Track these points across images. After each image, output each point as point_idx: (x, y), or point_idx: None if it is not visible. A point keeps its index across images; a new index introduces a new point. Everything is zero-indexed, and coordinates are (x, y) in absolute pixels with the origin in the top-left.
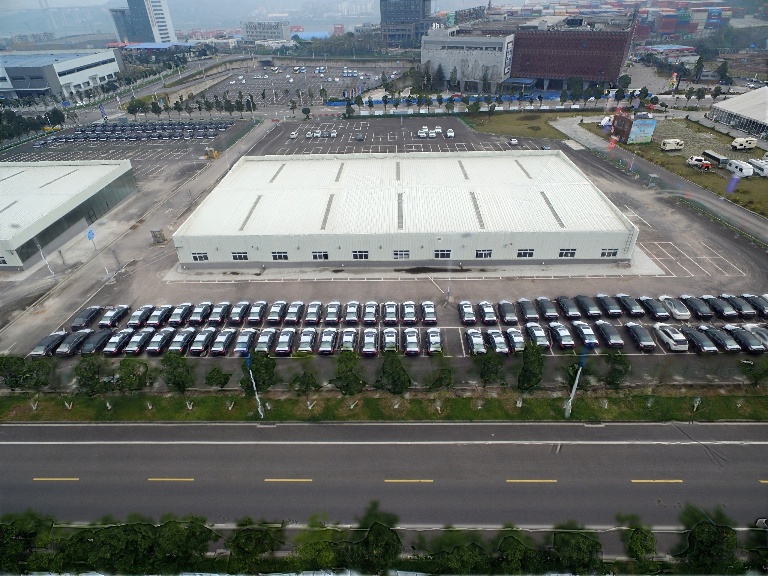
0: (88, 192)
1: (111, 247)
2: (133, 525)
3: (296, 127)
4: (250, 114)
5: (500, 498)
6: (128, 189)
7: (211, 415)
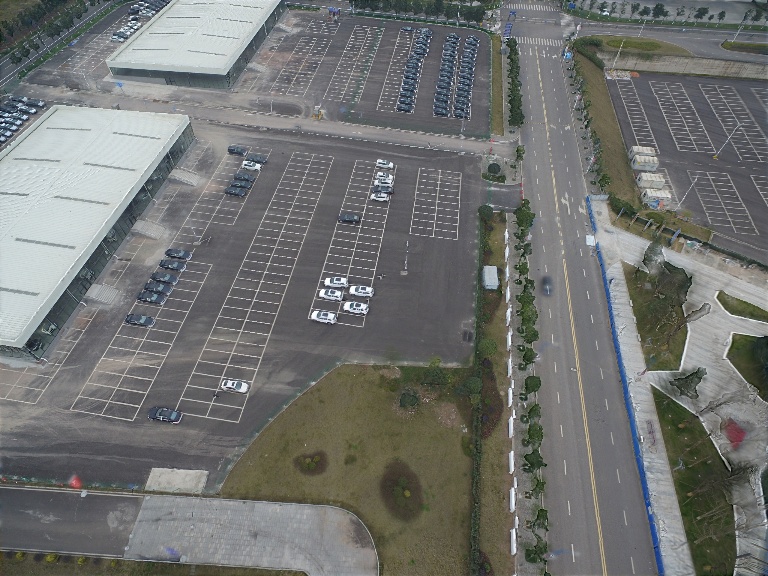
0: (172, 68)
1: (128, 98)
2: None
3: (443, 168)
4: (536, 128)
5: None
6: (217, 85)
7: None
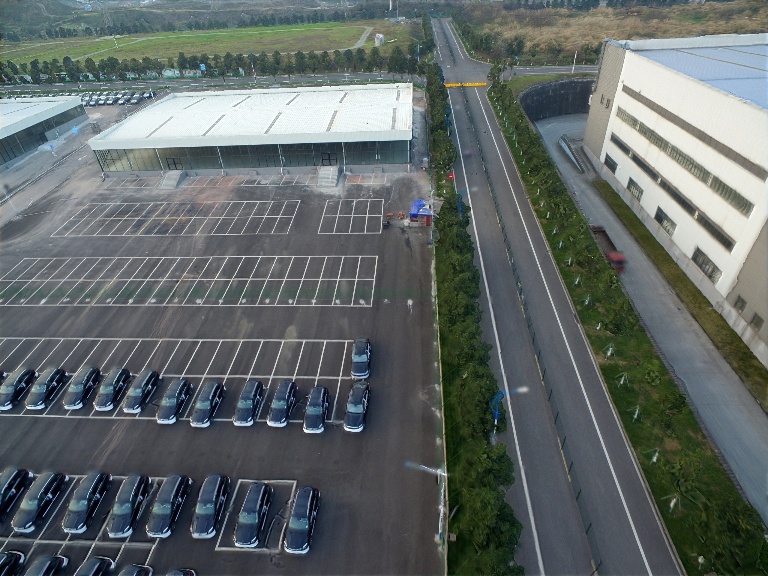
0: None
1: None
2: (110, 62)
3: None
4: None
5: (37, 86)
6: None
7: (97, 89)
